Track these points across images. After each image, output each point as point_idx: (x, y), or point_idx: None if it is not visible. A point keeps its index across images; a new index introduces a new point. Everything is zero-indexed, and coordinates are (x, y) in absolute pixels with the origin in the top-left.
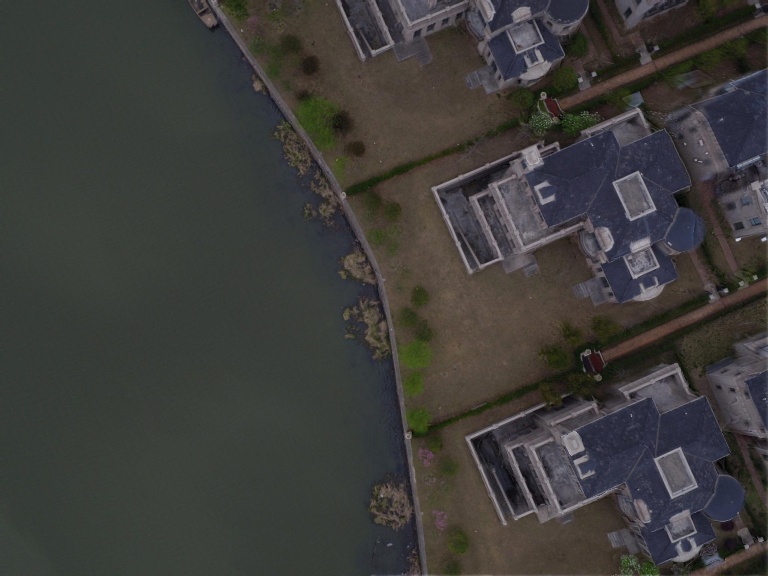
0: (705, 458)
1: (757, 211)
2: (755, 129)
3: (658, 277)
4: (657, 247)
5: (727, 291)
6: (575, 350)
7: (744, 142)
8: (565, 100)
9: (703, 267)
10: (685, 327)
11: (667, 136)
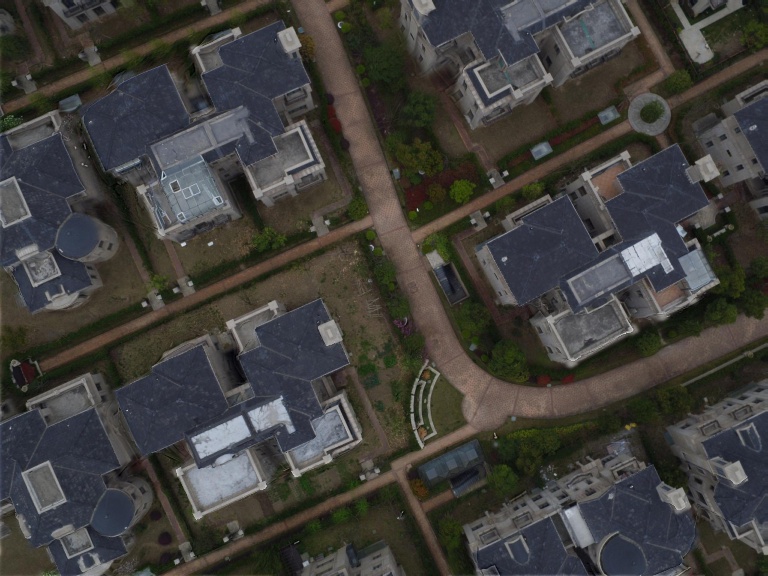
0: (88, 471)
1: (154, 216)
2: (119, 131)
3: (64, 285)
4: (55, 254)
5: (160, 298)
6: (4, 360)
7: (112, 145)
8: (10, 104)
9: (147, 273)
10: (126, 335)
11: (59, 140)
